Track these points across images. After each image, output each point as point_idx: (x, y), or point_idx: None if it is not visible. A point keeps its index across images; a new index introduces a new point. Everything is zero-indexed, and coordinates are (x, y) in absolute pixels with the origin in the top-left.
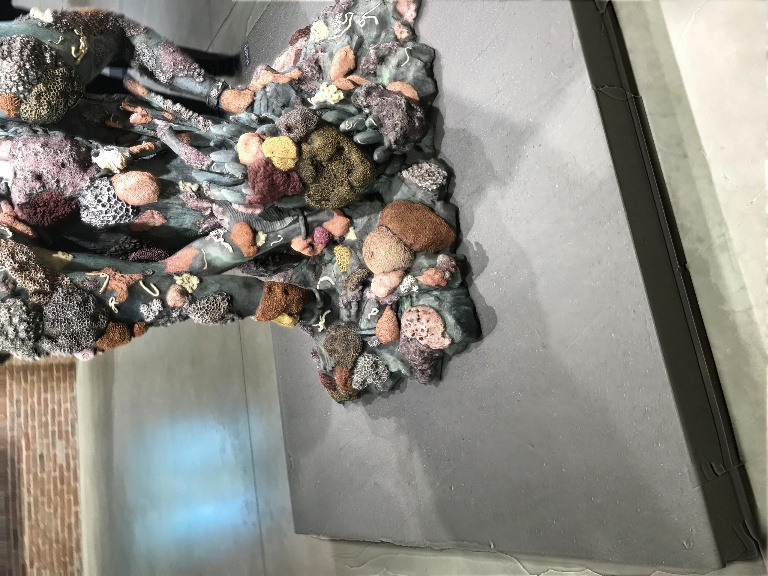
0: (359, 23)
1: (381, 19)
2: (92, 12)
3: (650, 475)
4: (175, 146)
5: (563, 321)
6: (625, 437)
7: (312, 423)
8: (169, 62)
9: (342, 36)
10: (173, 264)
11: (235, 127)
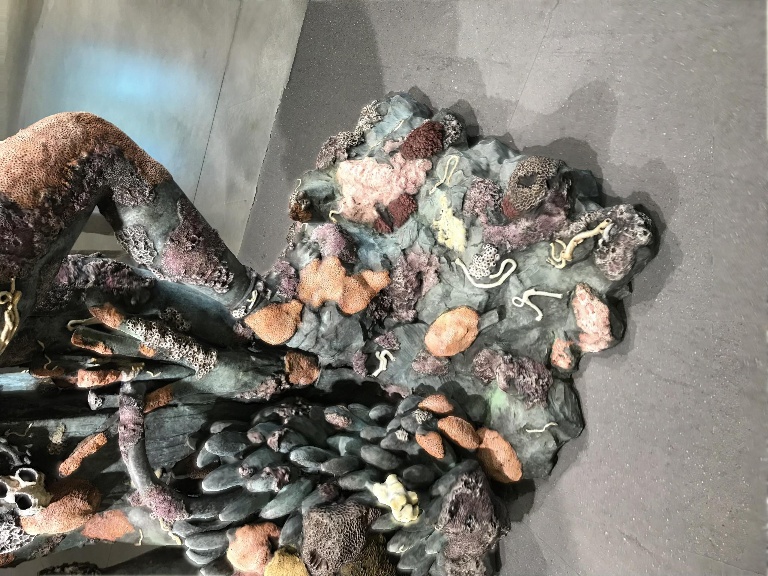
0: (513, 296)
1: (547, 319)
2: (50, 177)
3: None
4: (138, 486)
5: None
6: None
7: None
8: (178, 267)
9: (478, 288)
10: (95, 530)
11: (238, 518)
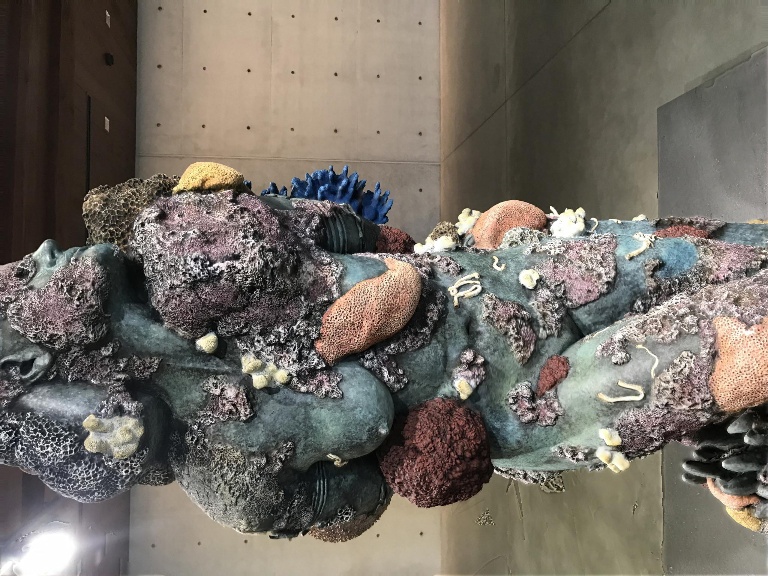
0: None
1: None
2: None
3: (692, 572)
4: None
5: (765, 575)
6: (707, 570)
7: (732, 154)
8: None
9: None
10: None
11: None
